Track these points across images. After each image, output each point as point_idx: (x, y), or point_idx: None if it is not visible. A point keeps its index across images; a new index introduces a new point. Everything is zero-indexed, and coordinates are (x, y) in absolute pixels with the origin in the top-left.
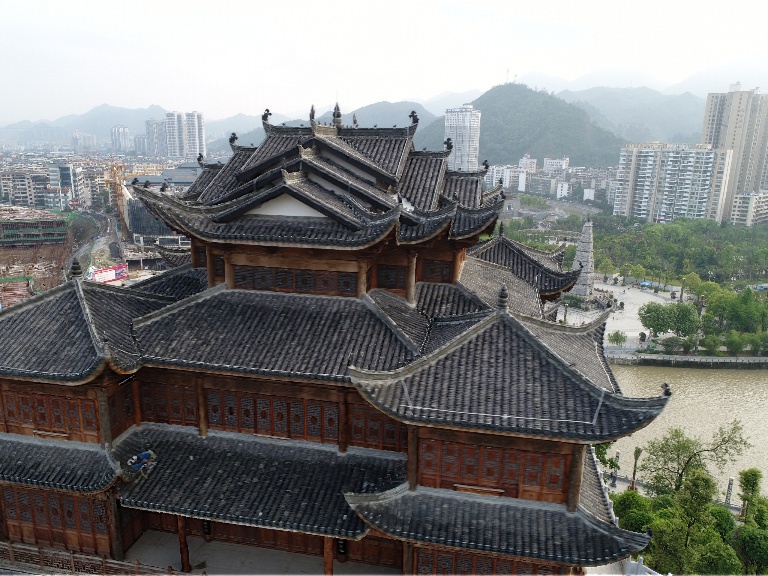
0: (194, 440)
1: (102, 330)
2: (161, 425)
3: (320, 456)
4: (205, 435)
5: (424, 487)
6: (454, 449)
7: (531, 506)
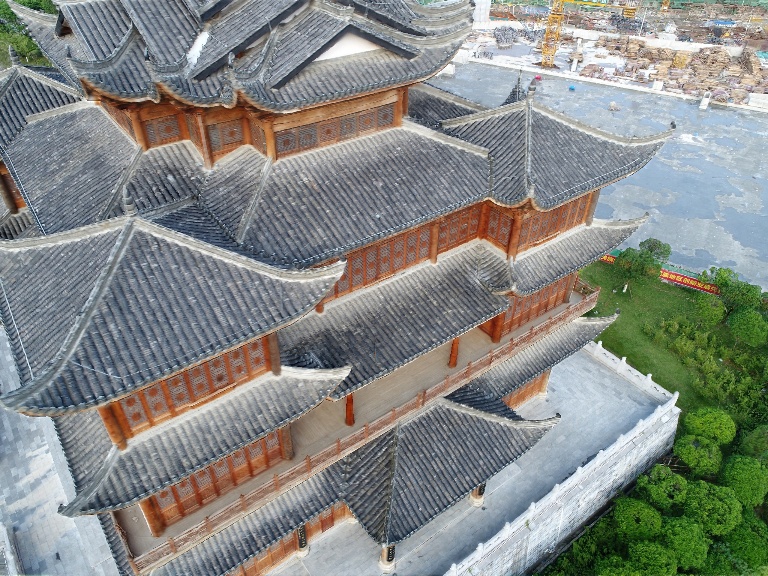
0: None
1: None
2: None
3: None
4: None
5: None
6: None
7: None
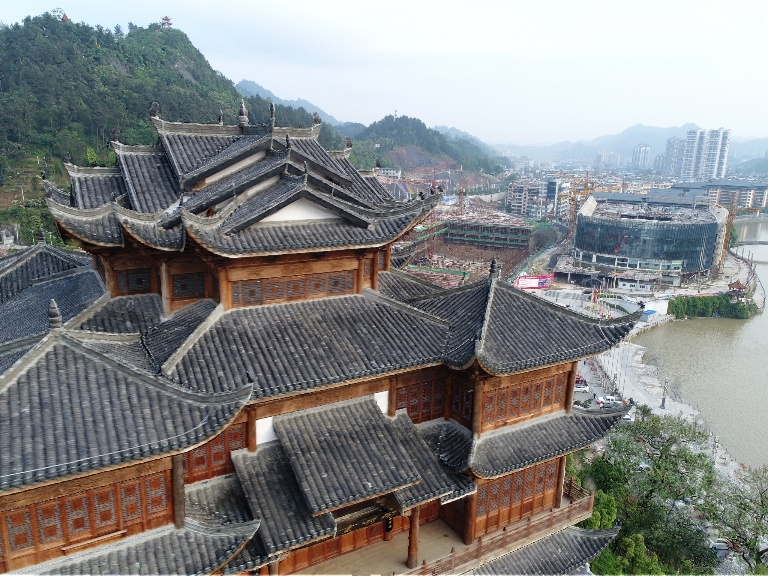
0: None
1: (2, 281)
2: None
3: None
4: None
5: None
6: None
7: None
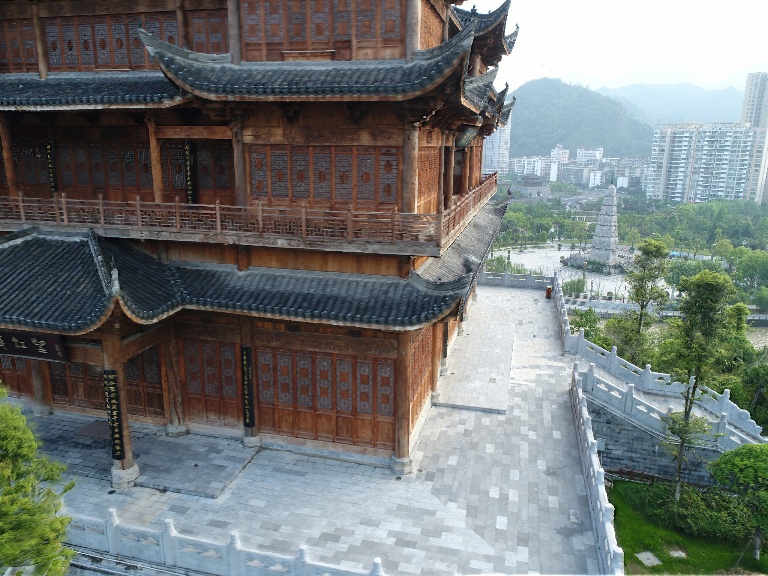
0: (31, 80)
1: None
2: (2, 75)
3: (158, 78)
4: (45, 78)
5: (249, 61)
6: (278, 4)
7: (366, 66)
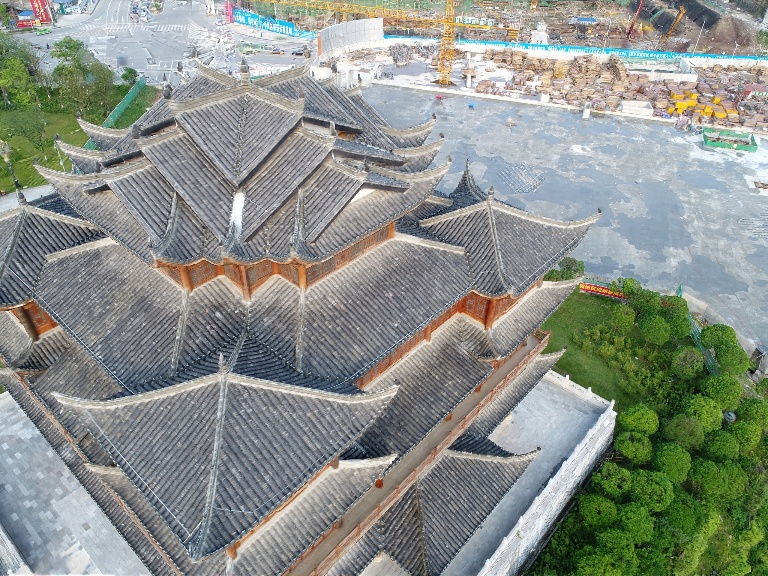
0: None
1: None
2: None
3: None
4: None
5: None
6: None
7: None
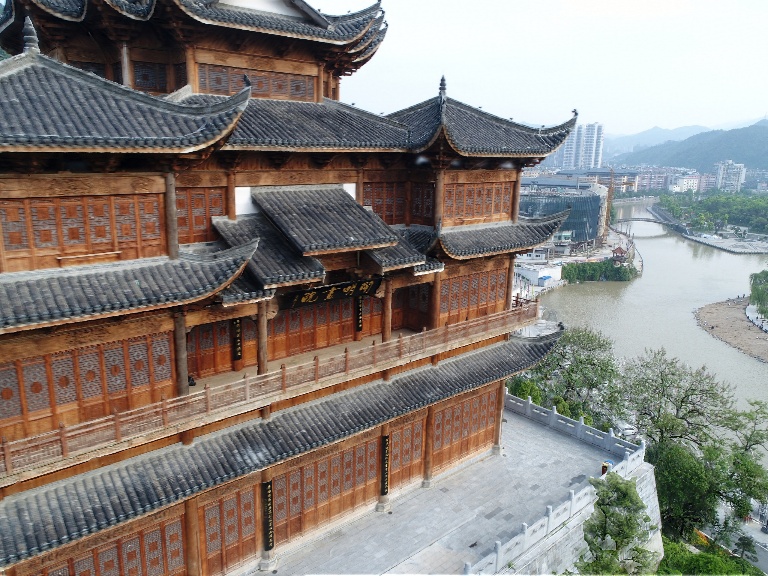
0: None
1: None
2: None
3: None
4: None
5: None
6: None
7: None
